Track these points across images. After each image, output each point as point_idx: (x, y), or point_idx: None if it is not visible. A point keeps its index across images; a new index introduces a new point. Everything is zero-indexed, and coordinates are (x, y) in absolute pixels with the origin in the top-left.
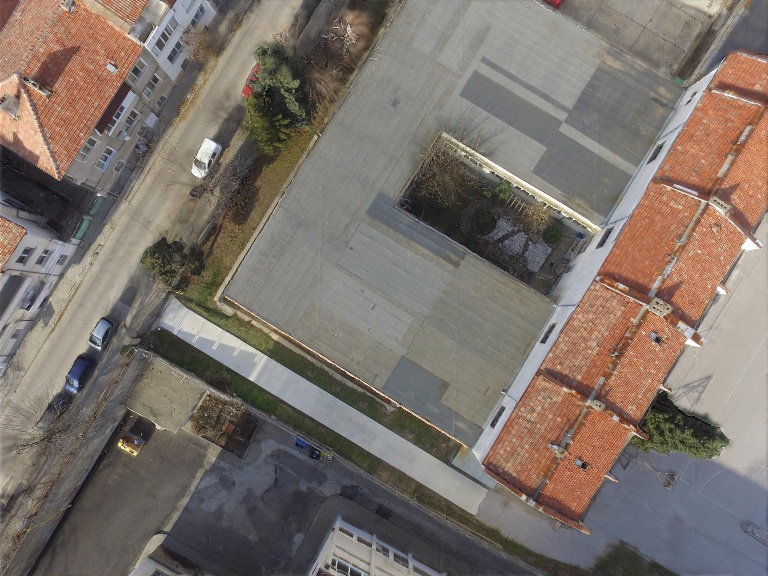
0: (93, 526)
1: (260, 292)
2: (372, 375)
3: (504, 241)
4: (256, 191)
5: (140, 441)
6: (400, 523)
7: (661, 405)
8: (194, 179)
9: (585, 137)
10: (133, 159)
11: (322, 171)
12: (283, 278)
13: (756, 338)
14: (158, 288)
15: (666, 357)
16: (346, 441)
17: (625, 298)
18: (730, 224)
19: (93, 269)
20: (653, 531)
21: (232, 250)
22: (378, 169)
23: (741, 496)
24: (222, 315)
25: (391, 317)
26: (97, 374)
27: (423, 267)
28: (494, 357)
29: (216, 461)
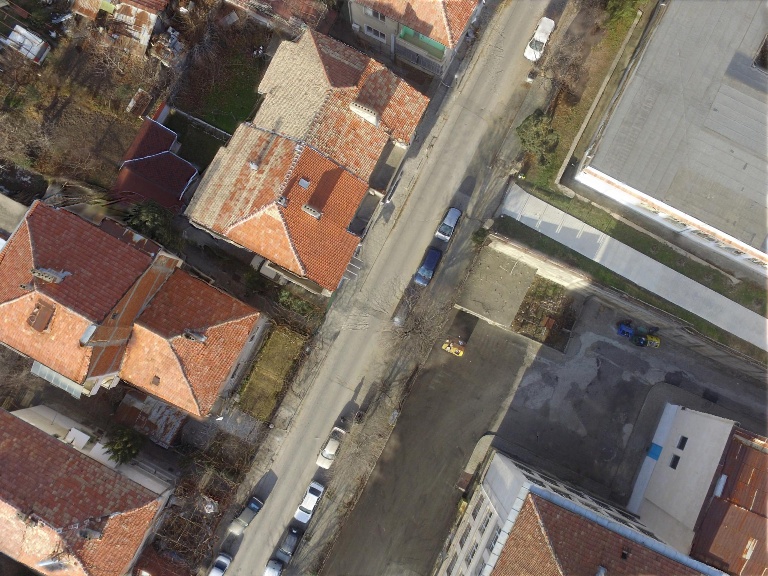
0: (419, 433)
1: (627, 161)
2: (750, 234)
3: None
4: (585, 72)
5: (463, 342)
6: (728, 405)
7: None
8: (525, 63)
9: None
10: (463, 48)
11: (676, 36)
12: (649, 145)
13: None
14: (516, 168)
15: None
16: (694, 317)
17: None
18: None
19: (429, 162)
20: None
21: (568, 132)
22: (733, 30)
23: None
24: (563, 198)
25: (764, 175)
26: (443, 266)
27: None
28: None
29: (536, 358)
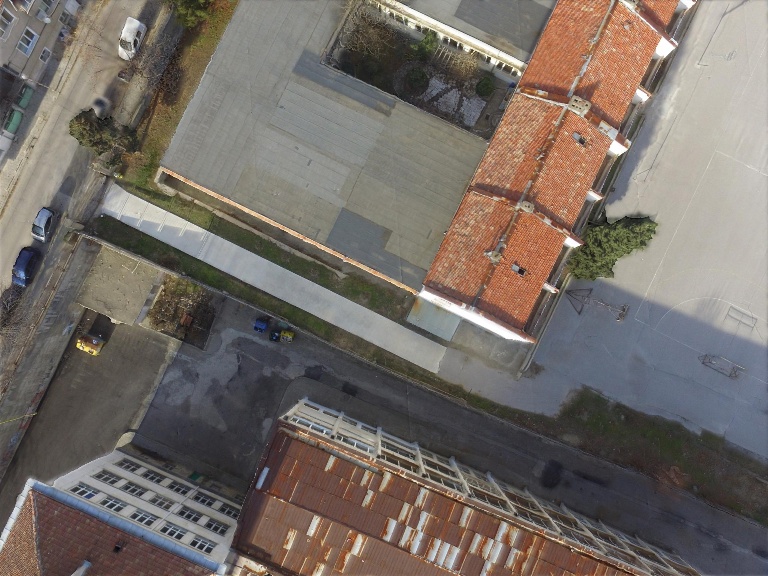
0: (60, 432)
1: (195, 159)
2: (314, 230)
3: (438, 99)
4: (186, 70)
5: (99, 341)
6: (367, 398)
7: (599, 223)
8: (122, 63)
9: None
10: (59, 48)
11: (246, 34)
12: (217, 143)
13: (696, 173)
14: (94, 168)
15: (592, 159)
16: (301, 312)
17: (546, 104)
18: (642, 22)
19: (30, 163)
20: (613, 372)
21: (168, 131)
22: (301, 27)
23: (696, 329)
24: (164, 196)
25: (328, 171)
26: (44, 267)
27: (355, 119)
28: (433, 200)
29: (178, 355)
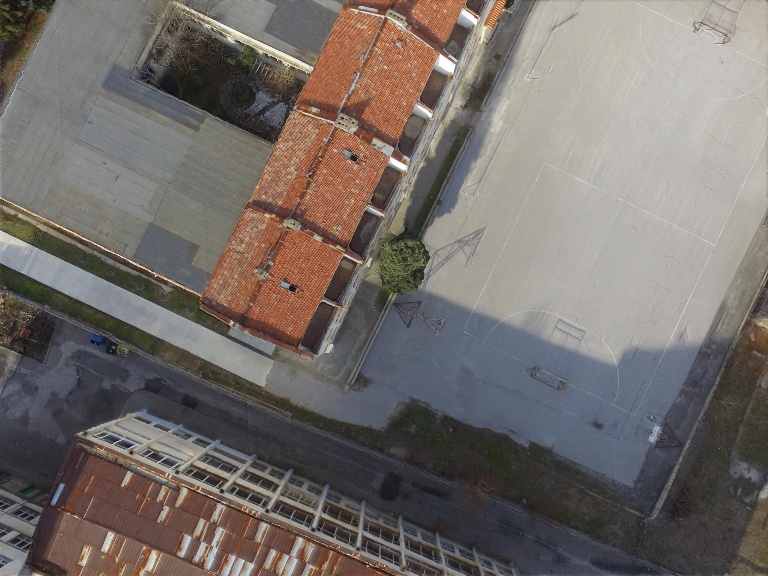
0: None
1: (4, 175)
2: (122, 245)
3: (265, 113)
4: (10, 85)
5: None
6: (206, 411)
7: None
8: None
9: None
10: None
11: (57, 50)
12: (26, 159)
13: (525, 186)
14: None
15: (367, 176)
16: (126, 325)
17: (319, 121)
18: (417, 39)
19: None
20: (441, 385)
21: None
22: (112, 42)
23: (524, 341)
24: None
25: (135, 186)
26: None
27: (164, 134)
28: (240, 215)
29: (17, 368)
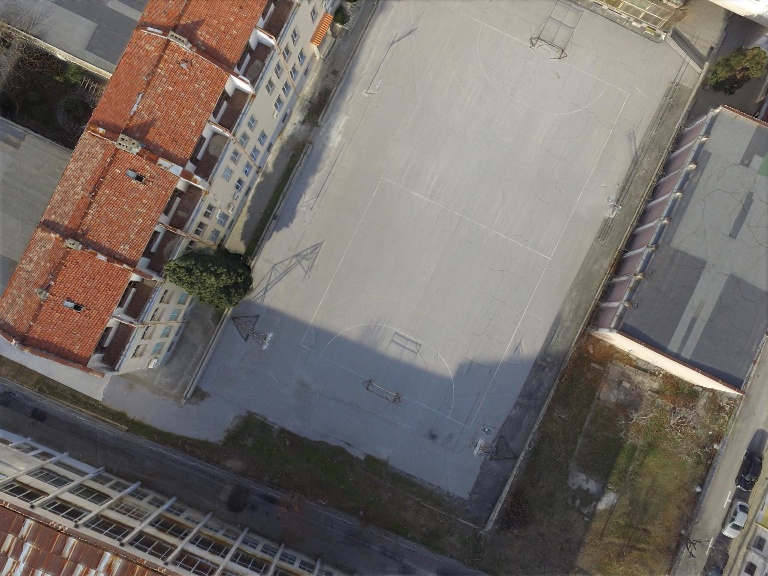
0: None
1: None
2: None
3: None
4: None
5: None
6: (55, 424)
7: None
8: None
9: (132, 10)
10: None
11: None
12: None
13: (363, 200)
14: None
15: (156, 196)
16: None
17: (105, 141)
18: (204, 60)
19: None
20: (278, 398)
21: None
22: None
23: (361, 355)
24: None
25: None
26: None
27: None
28: None
29: None
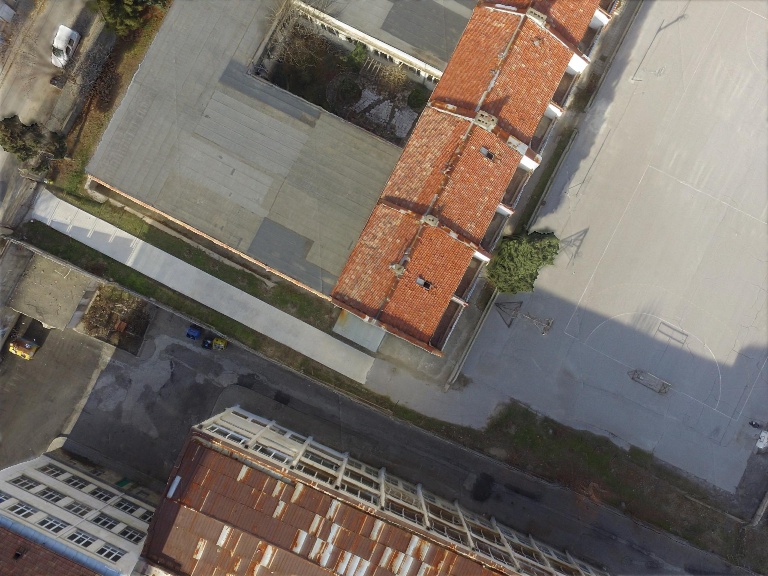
0: None
1: (120, 167)
2: (236, 239)
3: (371, 110)
4: (119, 78)
5: (32, 345)
6: (299, 407)
7: (516, 237)
8: (56, 70)
9: None
10: None
11: (174, 44)
12: (142, 151)
13: (628, 188)
14: (21, 174)
15: (501, 174)
16: (229, 320)
17: (455, 118)
18: (553, 38)
19: None
20: (542, 386)
21: (99, 138)
22: (229, 37)
23: (626, 344)
24: (94, 203)
25: (251, 180)
26: None
27: (280, 129)
28: (355, 211)
29: (111, 361)
